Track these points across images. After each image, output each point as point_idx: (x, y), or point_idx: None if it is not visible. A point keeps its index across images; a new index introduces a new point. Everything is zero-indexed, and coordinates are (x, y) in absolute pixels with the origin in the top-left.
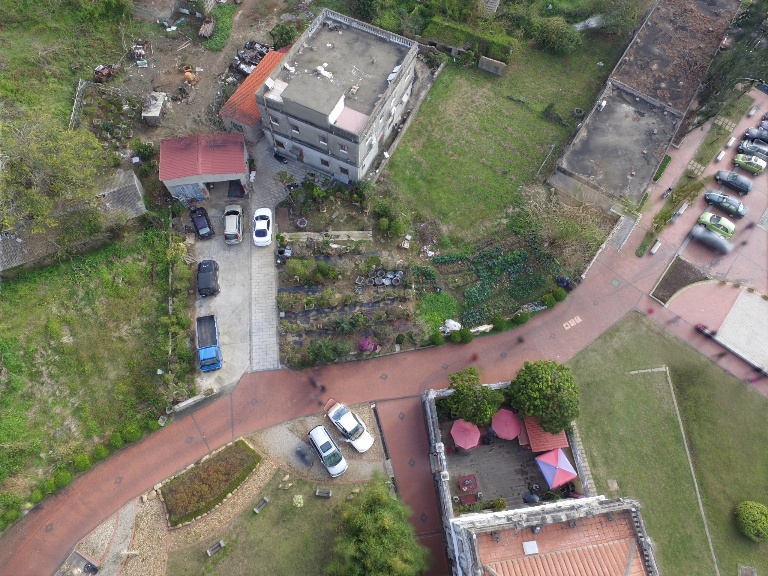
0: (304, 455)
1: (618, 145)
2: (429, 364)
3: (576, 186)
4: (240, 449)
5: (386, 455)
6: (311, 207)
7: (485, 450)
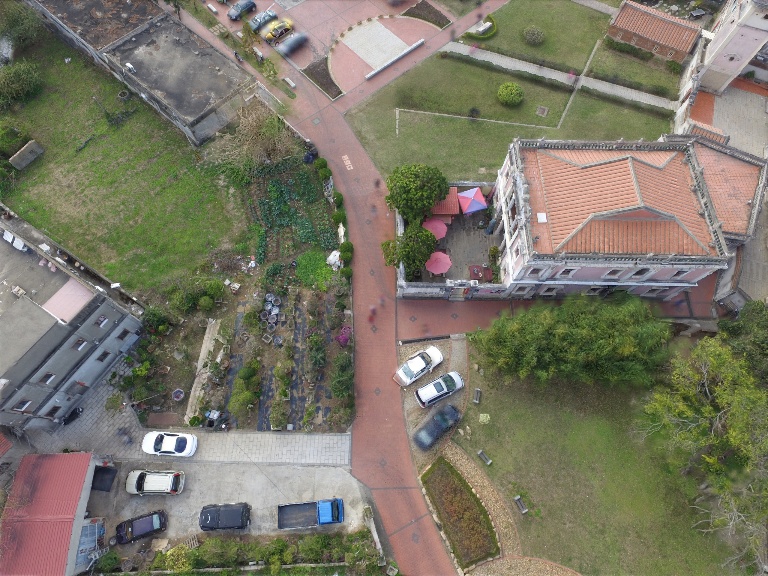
0: (441, 413)
1: (182, 70)
2: (368, 286)
3: (213, 119)
4: (432, 477)
5: (446, 338)
6: (158, 383)
7: (449, 255)
